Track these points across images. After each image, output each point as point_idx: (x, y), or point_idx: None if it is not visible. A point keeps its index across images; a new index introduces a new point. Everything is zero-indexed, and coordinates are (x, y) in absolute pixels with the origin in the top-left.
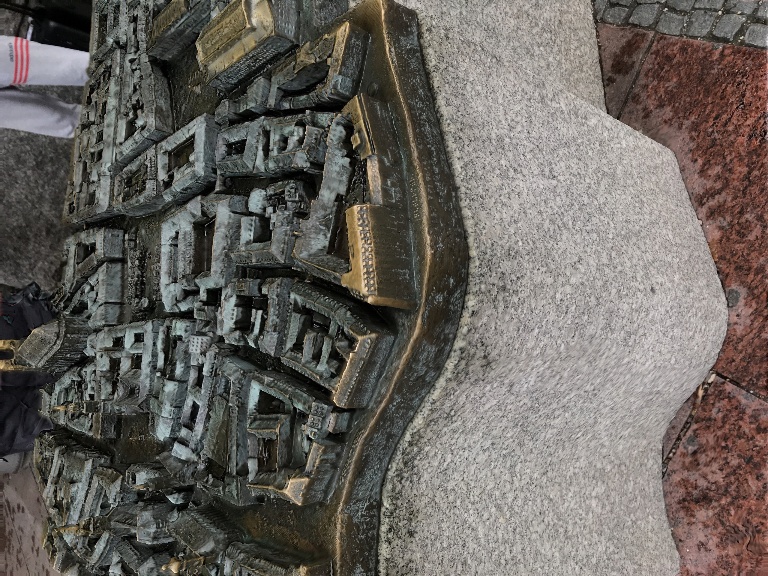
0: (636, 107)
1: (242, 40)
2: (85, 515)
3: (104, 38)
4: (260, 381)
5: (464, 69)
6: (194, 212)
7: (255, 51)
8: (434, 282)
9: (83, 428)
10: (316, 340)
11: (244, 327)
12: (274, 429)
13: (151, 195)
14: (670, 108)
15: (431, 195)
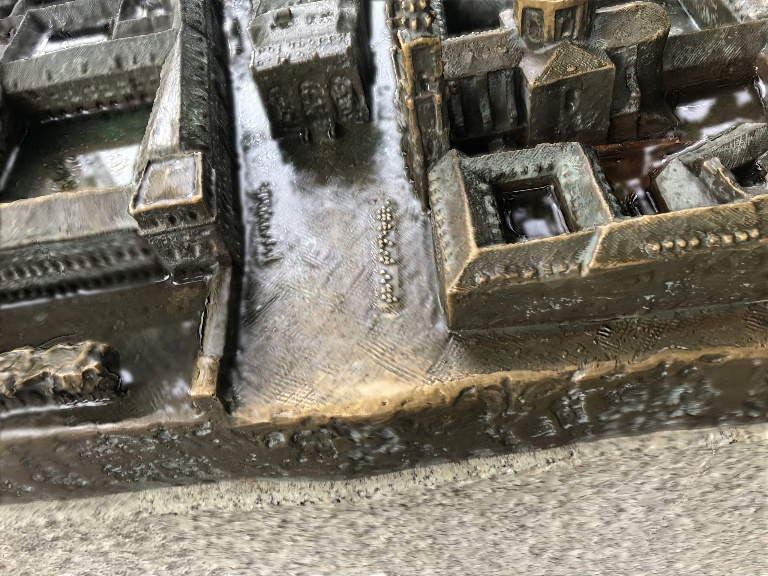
0: None
1: None
2: None
3: (700, 1)
4: None
5: None
6: None
7: None
8: None
9: None
10: None
11: None
12: None
13: None
14: None
15: None
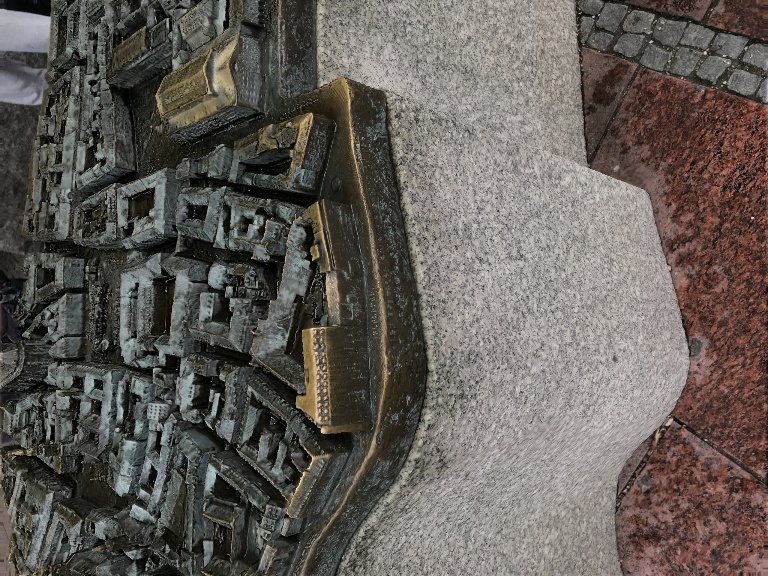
0: (615, 141)
1: (204, 103)
2: (46, 549)
3: (64, 42)
4: (216, 467)
5: (434, 153)
6: (154, 271)
7: (217, 115)
8: (390, 403)
9: (44, 459)
10: (272, 441)
11: (202, 404)
12: (229, 522)
13: (111, 238)
14: (648, 147)
15: (391, 311)
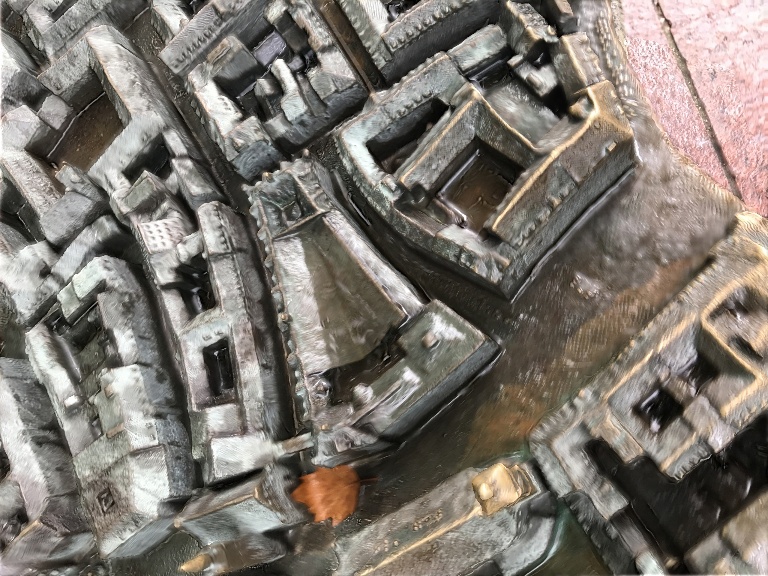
0: None
1: None
2: None
3: None
4: (362, 115)
5: None
6: (25, 120)
7: None
8: None
9: None
10: None
11: None
12: (468, 101)
13: None
14: None
15: None
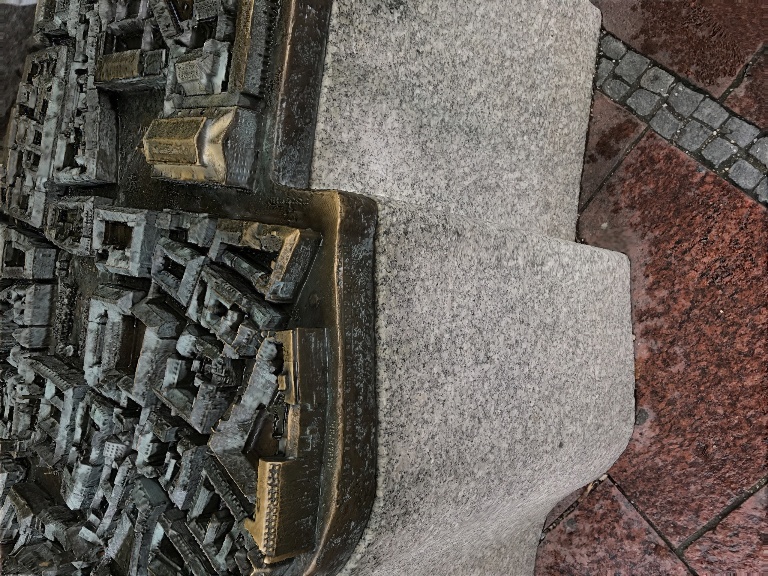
0: (608, 198)
1: (192, 166)
2: None
3: (53, 1)
4: (165, 528)
5: (418, 265)
6: (124, 309)
7: None
8: (334, 531)
9: (1, 437)
10: (219, 529)
11: (158, 460)
12: None
13: (84, 253)
14: (639, 213)
15: (348, 445)
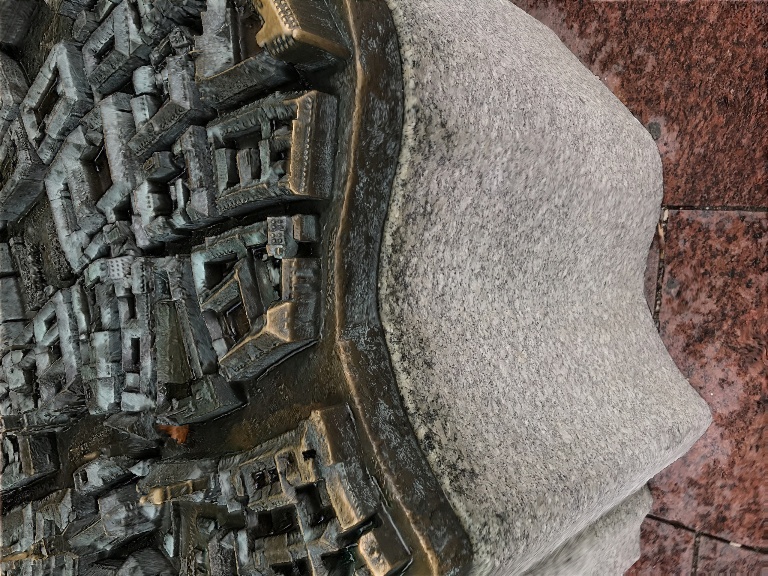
0: None
1: None
2: (37, 570)
3: None
4: (200, 248)
5: None
6: (77, 142)
7: None
8: (361, 24)
9: (11, 476)
10: (250, 156)
11: (166, 215)
12: (232, 278)
13: (26, 166)
14: None
15: None
